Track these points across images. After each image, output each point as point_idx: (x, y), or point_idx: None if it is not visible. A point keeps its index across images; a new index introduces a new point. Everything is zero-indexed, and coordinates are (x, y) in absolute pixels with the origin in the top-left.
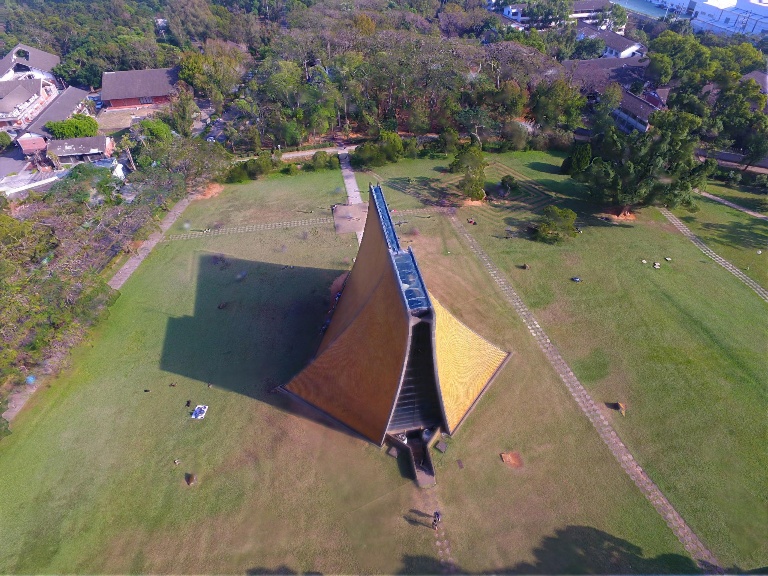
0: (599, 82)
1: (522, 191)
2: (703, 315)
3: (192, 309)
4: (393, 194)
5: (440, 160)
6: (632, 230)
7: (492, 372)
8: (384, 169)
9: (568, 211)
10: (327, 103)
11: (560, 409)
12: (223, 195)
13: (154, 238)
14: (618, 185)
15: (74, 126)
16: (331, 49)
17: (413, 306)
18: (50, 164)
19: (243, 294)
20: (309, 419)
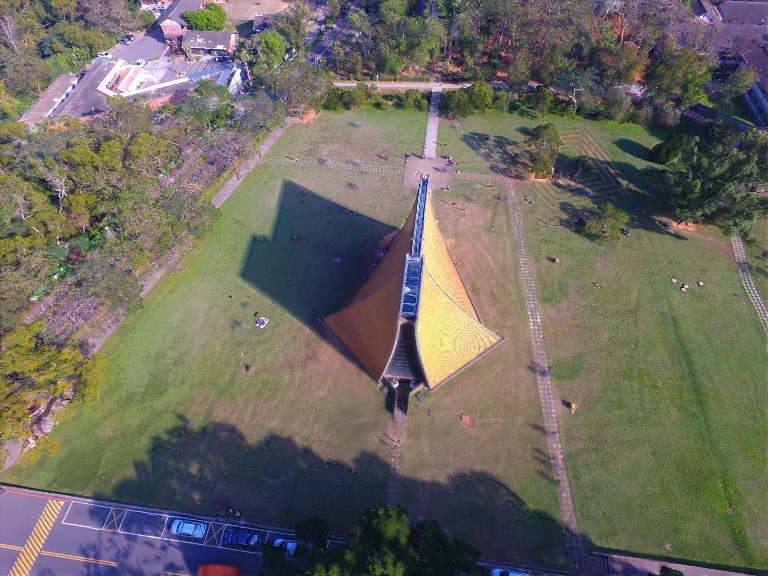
0: (746, 47)
1: (594, 173)
2: (697, 349)
3: (272, 235)
4: (466, 153)
5: (528, 119)
6: (684, 243)
7: (482, 350)
8: (469, 120)
9: (621, 213)
10: (434, 33)
11: (523, 394)
12: (318, 123)
13: (255, 158)
14: (686, 196)
15: (206, 18)
16: None
17: None
18: (184, 53)
19: (312, 231)
20: (334, 349)
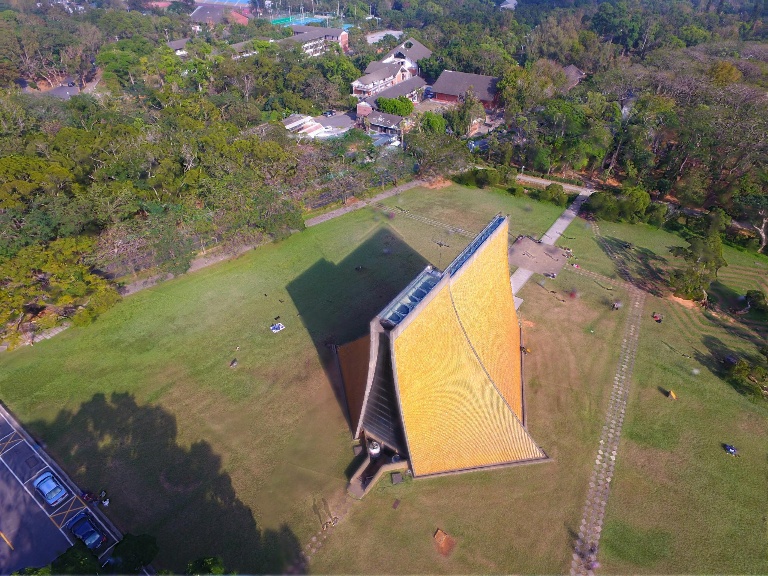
0: None
1: None
2: None
3: (340, 260)
4: (594, 251)
5: None
6: None
7: (508, 459)
8: (611, 225)
9: None
10: (599, 141)
11: (544, 547)
12: (444, 190)
13: None
14: None
15: (394, 105)
16: (661, 92)
17: None
18: None
19: (380, 268)
20: (330, 381)
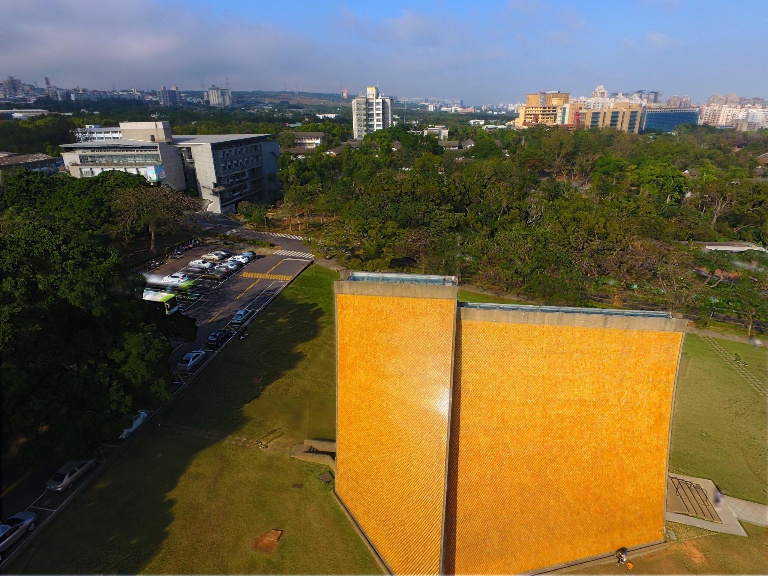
0: None
1: None
2: None
3: None
4: None
5: None
6: None
7: None
8: None
9: None
10: None
11: None
12: None
13: (705, 332)
14: None
15: None
16: None
17: None
18: None
19: None
20: None
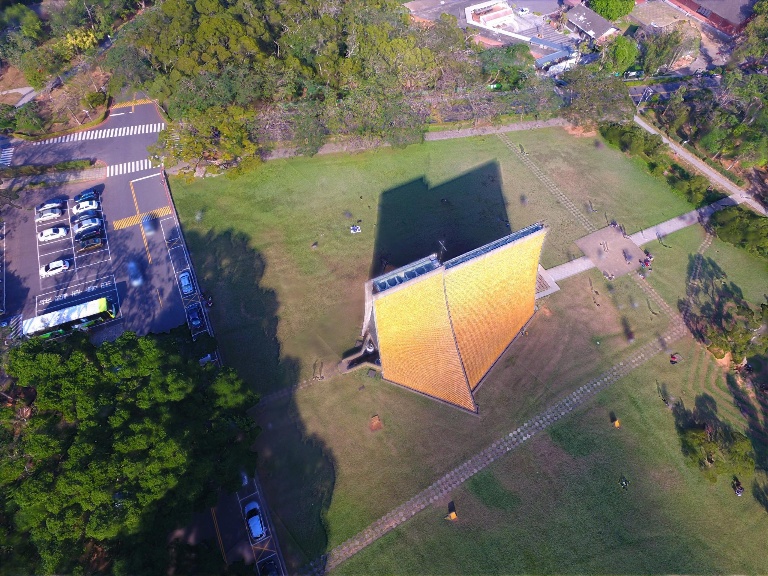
0: None
1: None
2: None
3: (435, 186)
4: (676, 269)
5: None
6: None
7: (449, 400)
8: (727, 248)
9: (747, 463)
10: None
11: (433, 460)
12: (581, 140)
13: None
14: None
15: (607, 2)
16: None
17: None
18: None
19: (462, 207)
20: None
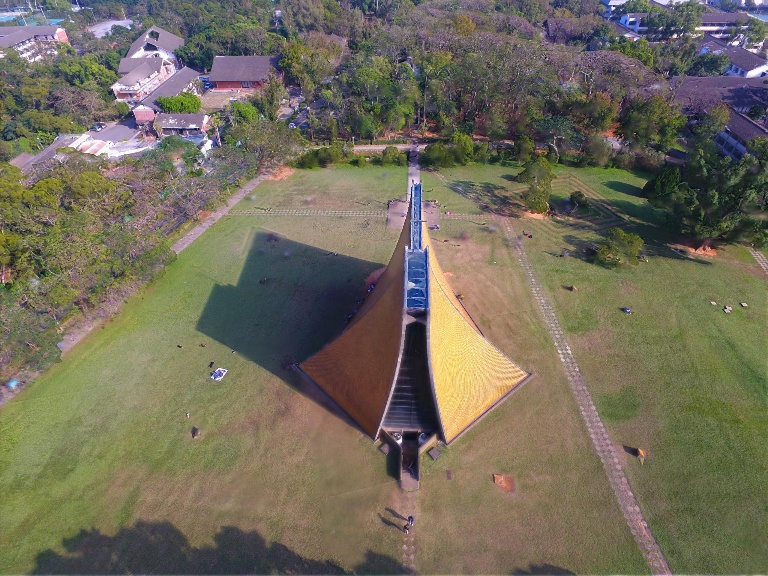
0: (709, 102)
1: (592, 210)
2: None
3: (237, 280)
4: (453, 197)
5: (511, 168)
6: (709, 267)
7: (506, 390)
8: (451, 171)
9: (634, 236)
10: (407, 100)
11: (571, 442)
12: (292, 179)
13: (222, 210)
14: (700, 215)
15: (180, 102)
16: (425, 48)
17: (416, 306)
18: (155, 134)
19: (285, 273)
20: (314, 400)
